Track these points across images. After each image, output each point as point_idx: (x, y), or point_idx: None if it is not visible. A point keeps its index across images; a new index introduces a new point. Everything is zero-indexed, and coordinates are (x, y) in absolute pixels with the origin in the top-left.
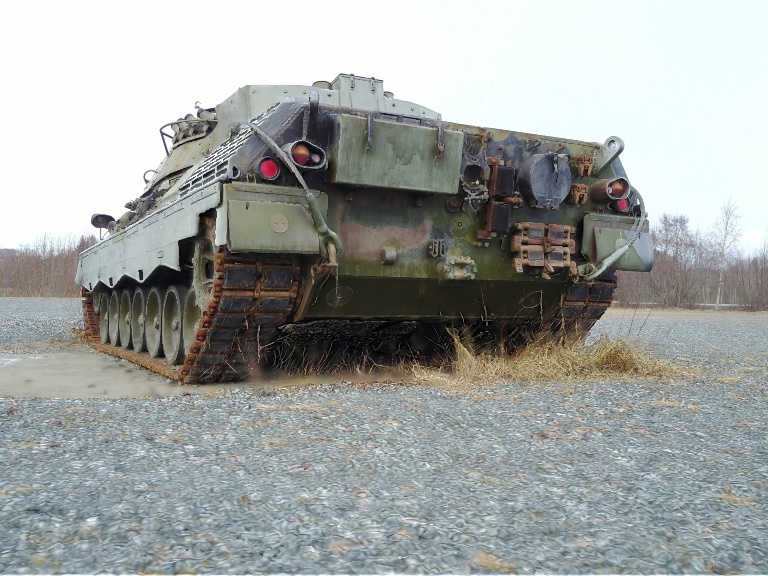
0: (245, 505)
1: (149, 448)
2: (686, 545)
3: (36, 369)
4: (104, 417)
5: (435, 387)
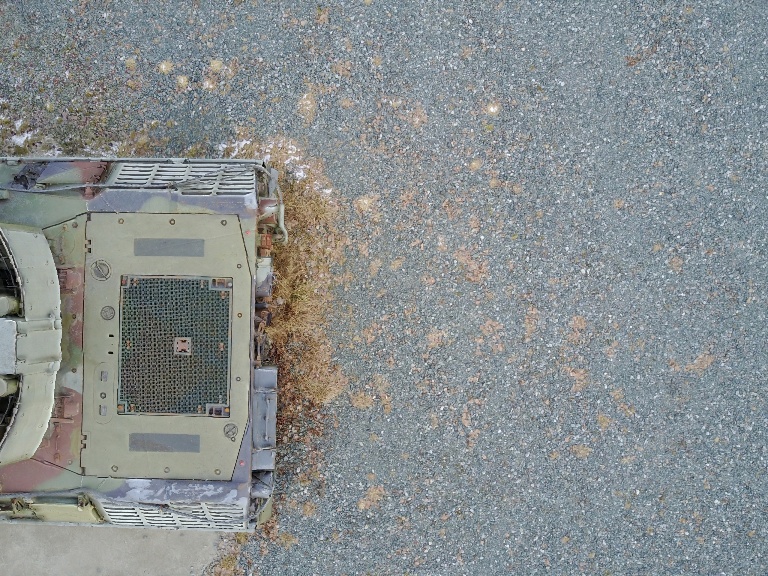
0: (515, 569)
1: (435, 572)
2: (577, 496)
3: (4, 556)
4: (371, 575)
5: (333, 397)
